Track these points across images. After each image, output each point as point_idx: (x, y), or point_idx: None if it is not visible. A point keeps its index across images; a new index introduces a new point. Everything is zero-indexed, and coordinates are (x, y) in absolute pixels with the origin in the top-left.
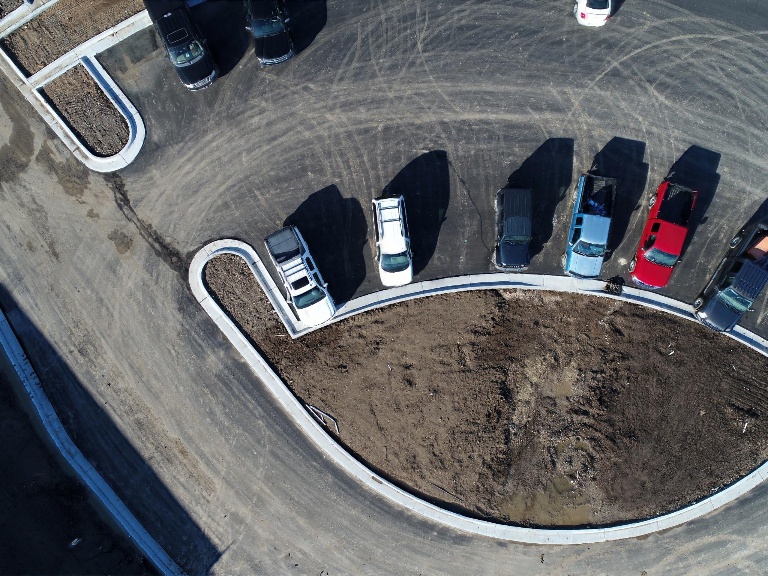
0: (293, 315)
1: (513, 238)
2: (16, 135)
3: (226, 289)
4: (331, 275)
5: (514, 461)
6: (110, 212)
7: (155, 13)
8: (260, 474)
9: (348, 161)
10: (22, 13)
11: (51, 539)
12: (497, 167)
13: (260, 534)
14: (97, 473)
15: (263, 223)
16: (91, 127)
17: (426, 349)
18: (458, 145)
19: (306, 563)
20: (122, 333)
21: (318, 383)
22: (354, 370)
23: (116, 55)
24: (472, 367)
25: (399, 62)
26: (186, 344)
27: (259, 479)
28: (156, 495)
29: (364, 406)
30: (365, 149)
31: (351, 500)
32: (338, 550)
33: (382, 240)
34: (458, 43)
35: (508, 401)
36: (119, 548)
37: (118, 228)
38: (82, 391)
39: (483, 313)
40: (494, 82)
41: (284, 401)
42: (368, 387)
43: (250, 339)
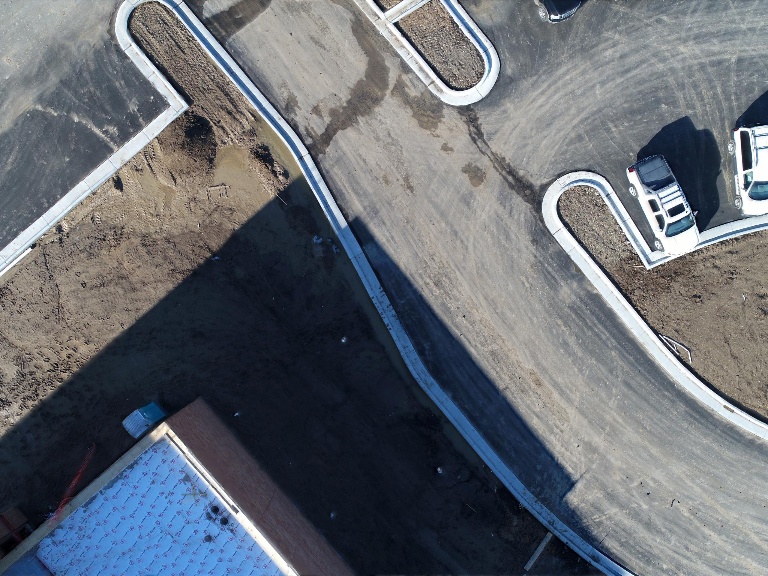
0: (647, 246)
1: None
2: (371, 70)
3: (580, 221)
4: None
5: None
6: (464, 145)
7: None
8: (612, 404)
9: (702, 93)
10: None
11: (410, 469)
12: None
13: (612, 463)
14: (453, 404)
15: (616, 155)
16: (447, 61)
17: None
18: None
19: (657, 492)
20: (476, 265)
21: (672, 313)
22: (708, 300)
23: None
24: None
25: None
26: (539, 276)
27: (611, 409)
28: (510, 425)
29: (718, 335)
30: (719, 81)
31: (702, 429)
32: (689, 479)
33: (756, 167)
34: None
35: None
36: (475, 478)
37: (472, 161)
38: (437, 323)
39: None
40: None
41: (637, 331)
42: (722, 316)
43: (603, 270)
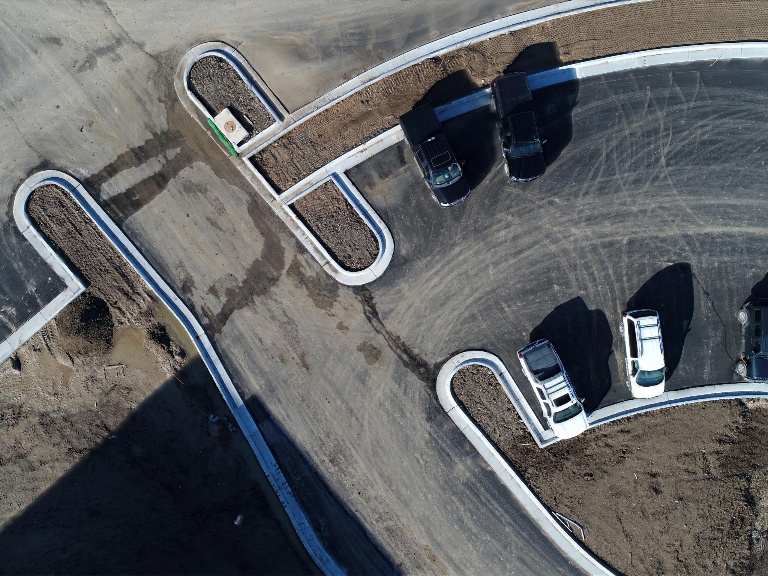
0: (540, 424)
1: (767, 353)
2: (267, 250)
3: (473, 399)
4: (577, 385)
5: (756, 566)
6: (359, 324)
7: (415, 135)
8: None
9: (593, 273)
10: (273, 131)
11: None
12: (740, 279)
13: None
14: None
15: (510, 334)
16: (341, 242)
17: (672, 458)
18: (702, 257)
19: None
20: (371, 443)
21: (565, 491)
22: (600, 478)
23: (365, 171)
24: (716, 475)
25: (643, 176)
26: (434, 453)
27: None
28: None
29: (610, 513)
30: (610, 262)
31: None
32: None
33: (641, 357)
34: (701, 157)
35: (752, 508)
36: None
37: (367, 340)
38: (333, 500)
39: (728, 422)
40: (737, 195)
41: (530, 508)
42: (614, 495)
43: (497, 448)
